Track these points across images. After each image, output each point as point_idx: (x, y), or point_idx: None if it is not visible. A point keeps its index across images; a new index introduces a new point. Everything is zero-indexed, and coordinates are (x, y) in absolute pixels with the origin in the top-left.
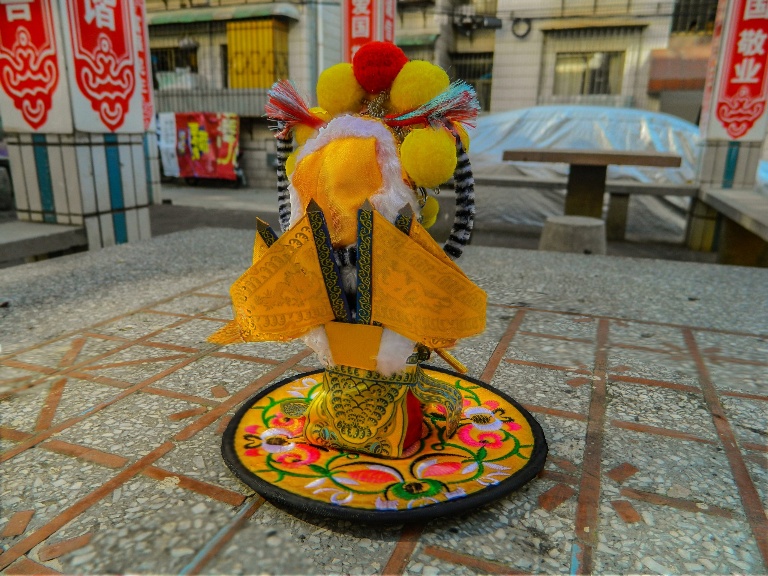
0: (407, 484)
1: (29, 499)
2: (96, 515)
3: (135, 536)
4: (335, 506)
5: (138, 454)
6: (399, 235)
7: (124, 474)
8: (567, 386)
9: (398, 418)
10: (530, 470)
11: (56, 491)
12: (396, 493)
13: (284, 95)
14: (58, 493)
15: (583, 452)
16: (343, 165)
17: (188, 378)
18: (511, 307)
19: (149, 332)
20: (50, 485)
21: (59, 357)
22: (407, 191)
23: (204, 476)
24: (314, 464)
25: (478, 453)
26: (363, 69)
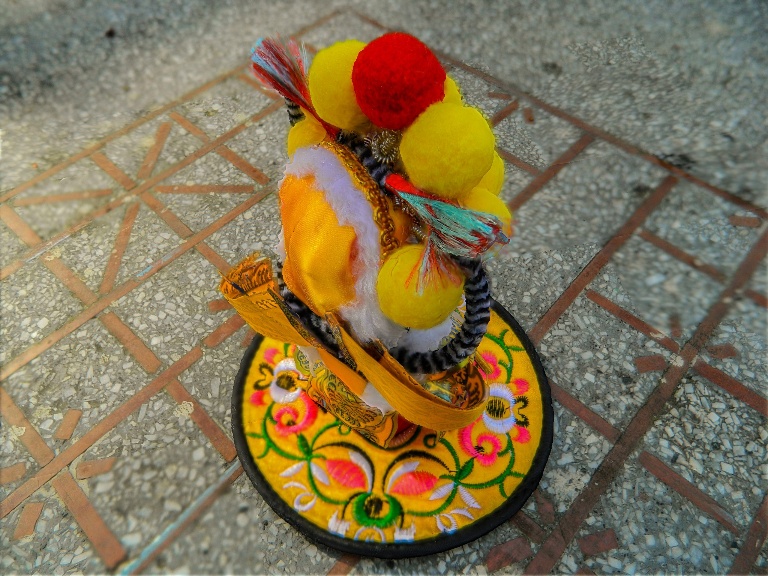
0: (371, 498)
1: (80, 394)
2: (122, 435)
3: (144, 473)
4: (294, 513)
5: (170, 358)
6: (369, 357)
7: (153, 385)
8: (631, 369)
9: (387, 425)
10: (495, 521)
11: (100, 391)
12: (354, 511)
13: (271, 65)
14: (101, 394)
15: (577, 495)
16: (311, 255)
17: (243, 236)
18: (663, 165)
19: (231, 126)
20: (98, 380)
21: (141, 158)
22: (383, 320)
23: (214, 410)
24: (303, 435)
25: (463, 467)
26: (360, 101)
